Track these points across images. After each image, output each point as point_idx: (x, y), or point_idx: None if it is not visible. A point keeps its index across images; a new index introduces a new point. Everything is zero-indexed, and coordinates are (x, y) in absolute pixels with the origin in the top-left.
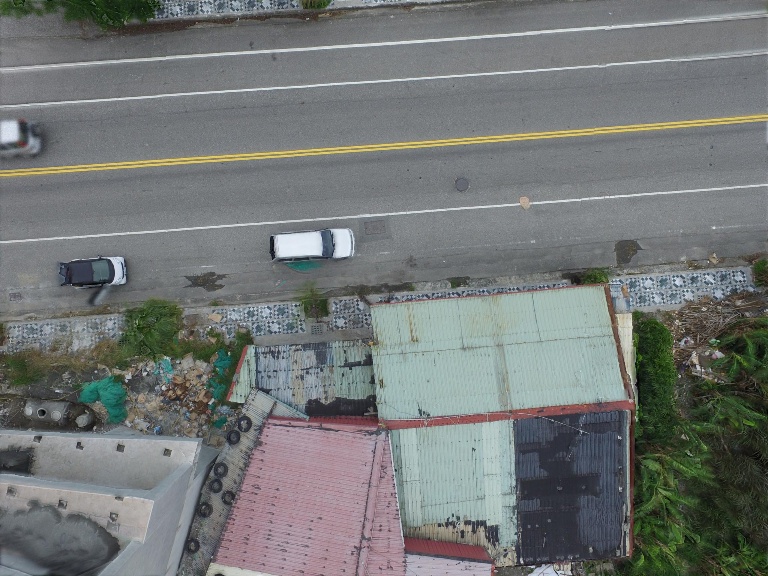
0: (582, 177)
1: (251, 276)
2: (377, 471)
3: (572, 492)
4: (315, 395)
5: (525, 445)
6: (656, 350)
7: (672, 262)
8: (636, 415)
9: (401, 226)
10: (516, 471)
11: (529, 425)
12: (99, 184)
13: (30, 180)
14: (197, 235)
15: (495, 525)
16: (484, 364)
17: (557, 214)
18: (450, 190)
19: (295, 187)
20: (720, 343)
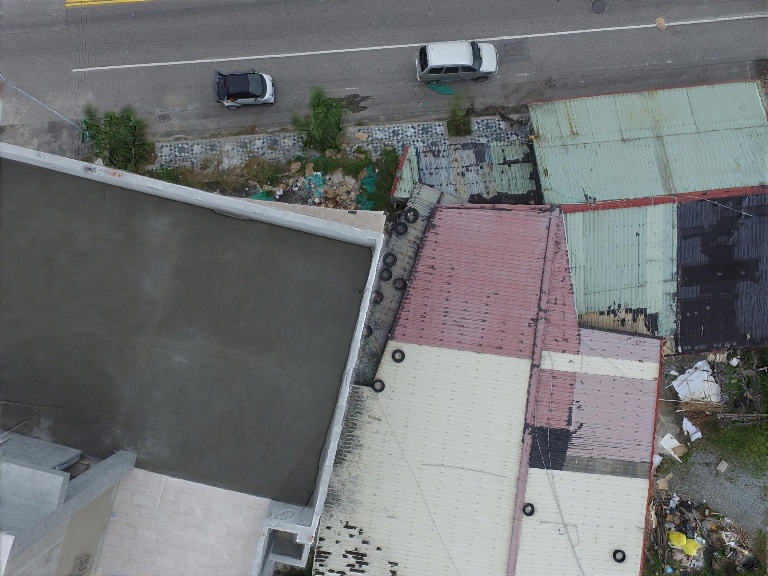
0: None
1: (394, 97)
2: (552, 246)
3: (732, 277)
4: (476, 191)
5: (688, 229)
6: None
7: None
8: None
9: (540, 48)
10: (678, 257)
11: (693, 208)
12: (245, 8)
13: (177, 4)
14: (341, 57)
15: (655, 313)
16: (644, 154)
17: (692, 35)
18: (587, 12)
19: (436, 10)
20: None
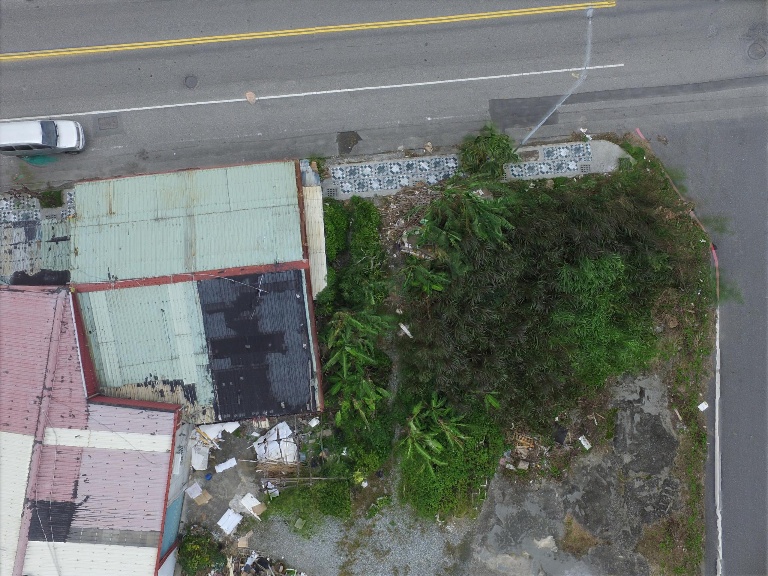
0: (304, 73)
1: None
2: (57, 326)
3: (259, 350)
4: (22, 268)
5: (211, 305)
6: (358, 226)
7: (390, 151)
8: (325, 280)
9: (133, 121)
10: (205, 331)
11: (211, 285)
12: None
13: None
14: None
15: (192, 384)
16: (175, 233)
17: (282, 108)
18: (180, 87)
19: (31, 86)
20: (428, 222)
